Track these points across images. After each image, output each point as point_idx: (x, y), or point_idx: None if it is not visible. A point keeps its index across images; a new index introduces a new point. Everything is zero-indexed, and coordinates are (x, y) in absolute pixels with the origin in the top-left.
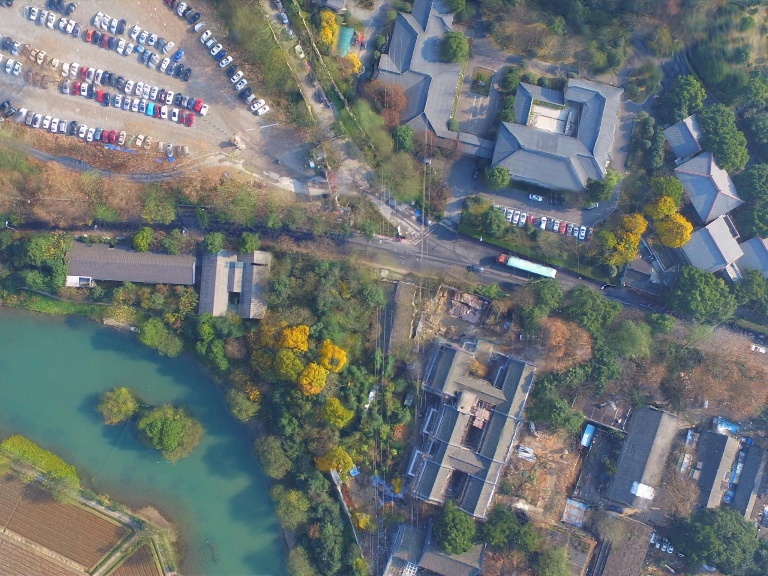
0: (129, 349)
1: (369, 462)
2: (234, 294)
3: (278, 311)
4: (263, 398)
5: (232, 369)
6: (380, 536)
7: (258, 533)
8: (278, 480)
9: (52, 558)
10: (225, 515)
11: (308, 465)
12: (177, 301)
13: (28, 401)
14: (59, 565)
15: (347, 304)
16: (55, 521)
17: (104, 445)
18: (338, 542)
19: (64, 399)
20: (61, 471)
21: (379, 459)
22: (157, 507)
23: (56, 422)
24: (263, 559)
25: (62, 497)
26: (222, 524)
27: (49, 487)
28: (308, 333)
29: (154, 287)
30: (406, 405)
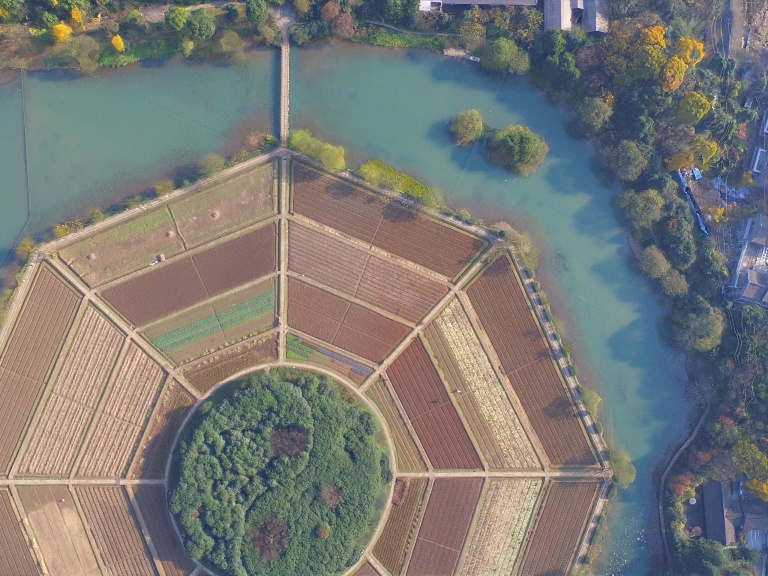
0: (469, 78)
1: (720, 158)
2: (578, 11)
3: (625, 21)
4: (617, 102)
5: (586, 77)
6: (725, 235)
7: (604, 242)
8: (632, 182)
9: (418, 270)
10: (572, 227)
11: (660, 165)
12: (524, 20)
13: (379, 130)
14: (425, 276)
15: (691, 10)
16: (417, 237)
17: (454, 167)
18: (691, 238)
19: (412, 127)
20: (418, 191)
21: (725, 158)
22: (509, 222)
23: (407, 148)
24: (611, 266)
25: (421, 215)
26: (570, 236)
27: (408, 206)
28: (664, 32)
29: (503, 7)
30: (747, 107)
